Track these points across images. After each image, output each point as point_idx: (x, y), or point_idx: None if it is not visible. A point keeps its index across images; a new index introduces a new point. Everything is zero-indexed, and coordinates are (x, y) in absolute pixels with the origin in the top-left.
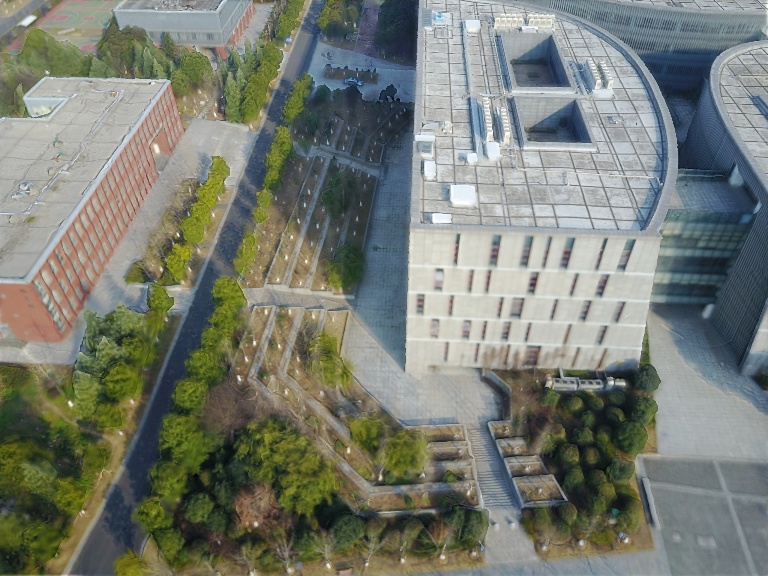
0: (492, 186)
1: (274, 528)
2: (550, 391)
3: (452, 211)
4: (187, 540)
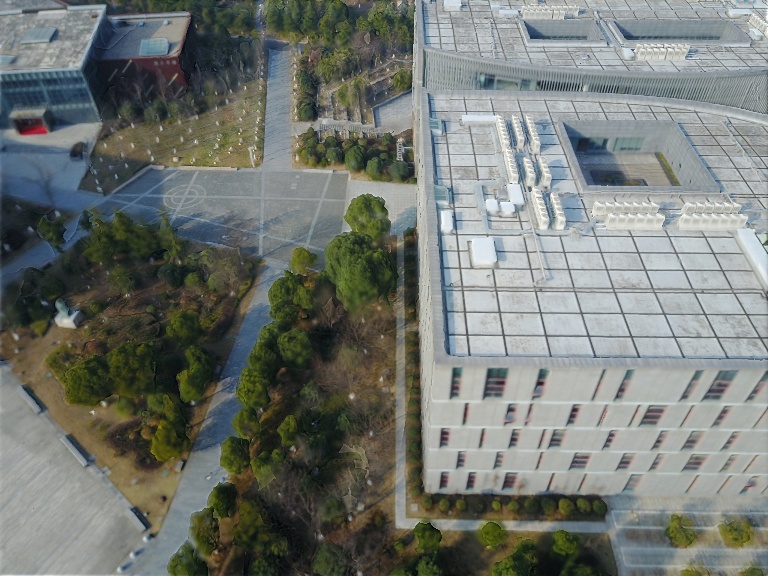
0: None
1: (309, 67)
2: (386, 133)
3: (439, 4)
4: None
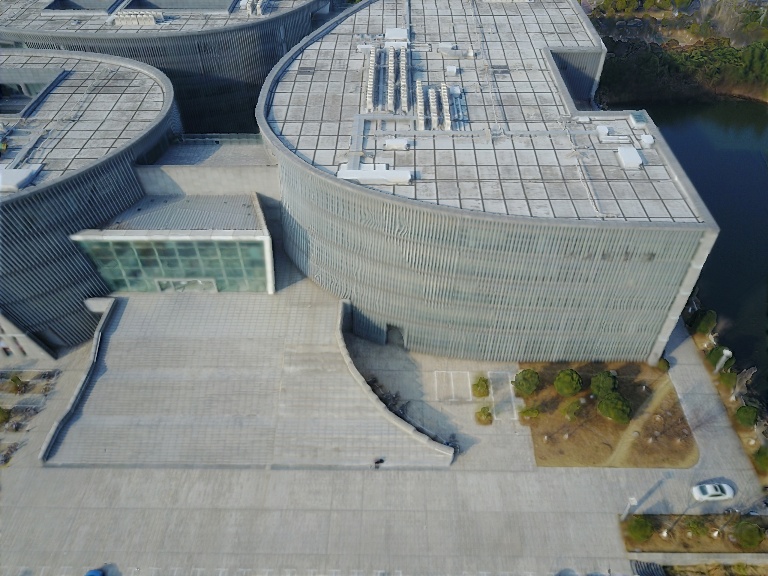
0: None
1: None
2: None
3: None
4: None
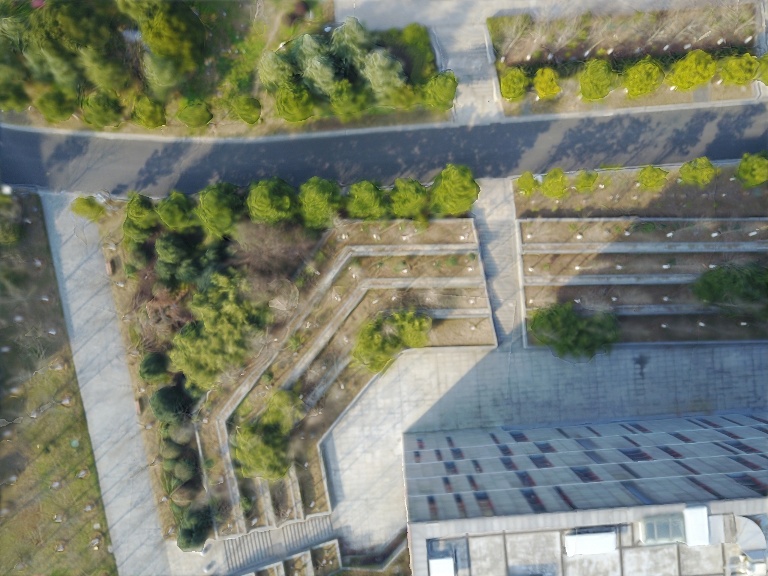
0: None
1: (155, 333)
2: None
3: None
4: (144, 245)
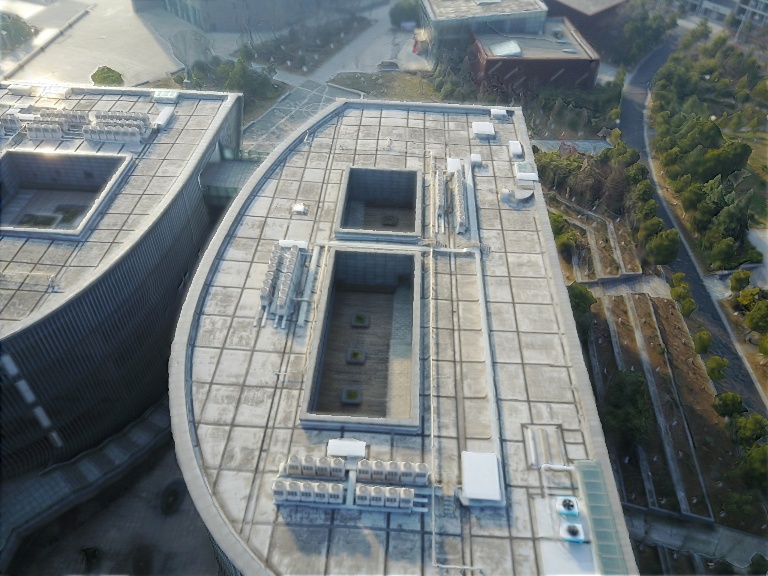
0: (457, 142)
1: None
2: None
3: None
4: None
